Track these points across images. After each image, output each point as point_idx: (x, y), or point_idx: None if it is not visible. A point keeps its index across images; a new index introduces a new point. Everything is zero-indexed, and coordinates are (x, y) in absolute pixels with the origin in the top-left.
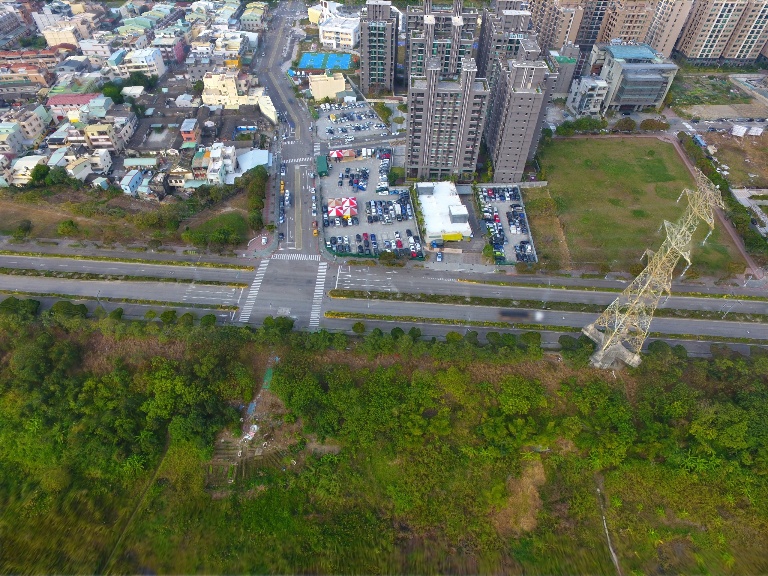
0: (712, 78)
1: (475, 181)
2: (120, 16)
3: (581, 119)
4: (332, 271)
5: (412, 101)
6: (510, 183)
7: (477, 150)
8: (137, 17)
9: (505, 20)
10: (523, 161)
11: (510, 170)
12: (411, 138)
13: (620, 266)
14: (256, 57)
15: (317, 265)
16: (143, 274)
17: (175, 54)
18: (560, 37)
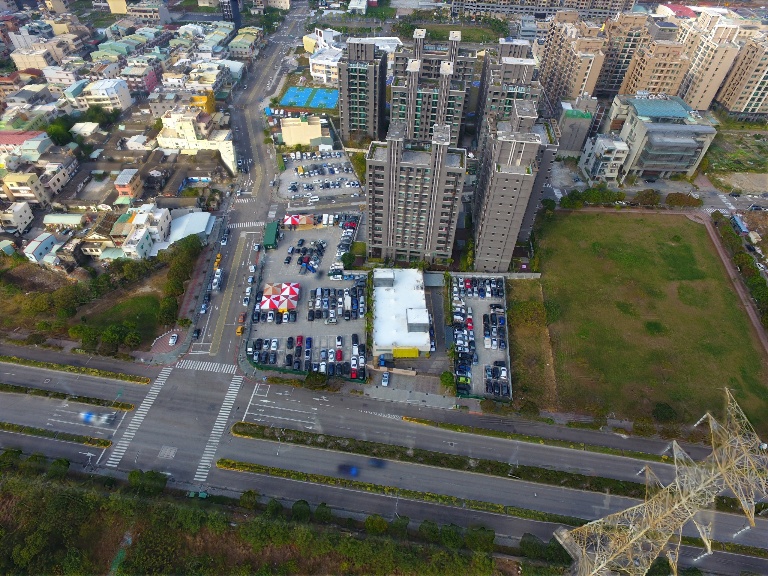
0: (758, 137)
1: (447, 272)
2: (106, 37)
3: (592, 189)
4: (245, 392)
5: (370, 174)
6: (494, 273)
7: (453, 233)
8: (113, 42)
9: (504, 69)
10: (510, 249)
11: (494, 258)
12: (371, 215)
13: (622, 410)
14: (231, 92)
15: (229, 381)
16: (12, 380)
17: (146, 85)
18: (576, 85)
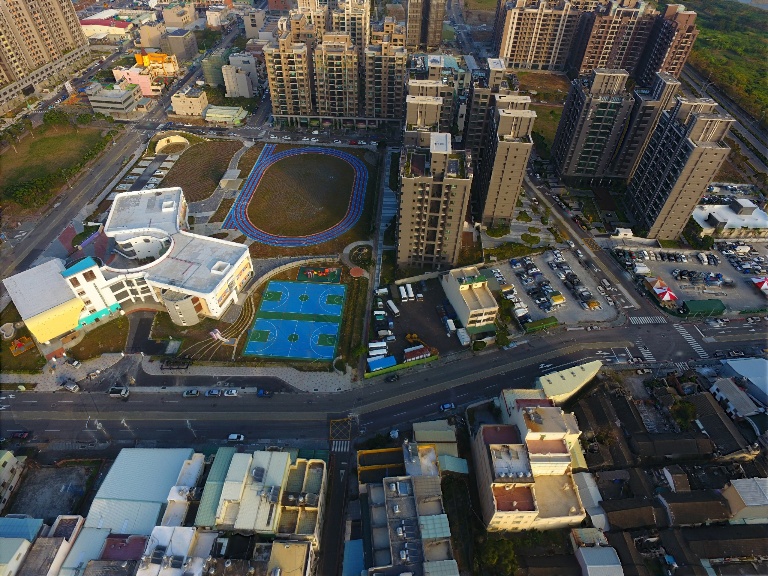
0: None
1: None
2: None
3: None
4: None
5: None
6: None
7: None
8: None
9: (502, 76)
10: None
11: None
12: None
13: None
14: None
15: None
16: None
17: None
18: None
